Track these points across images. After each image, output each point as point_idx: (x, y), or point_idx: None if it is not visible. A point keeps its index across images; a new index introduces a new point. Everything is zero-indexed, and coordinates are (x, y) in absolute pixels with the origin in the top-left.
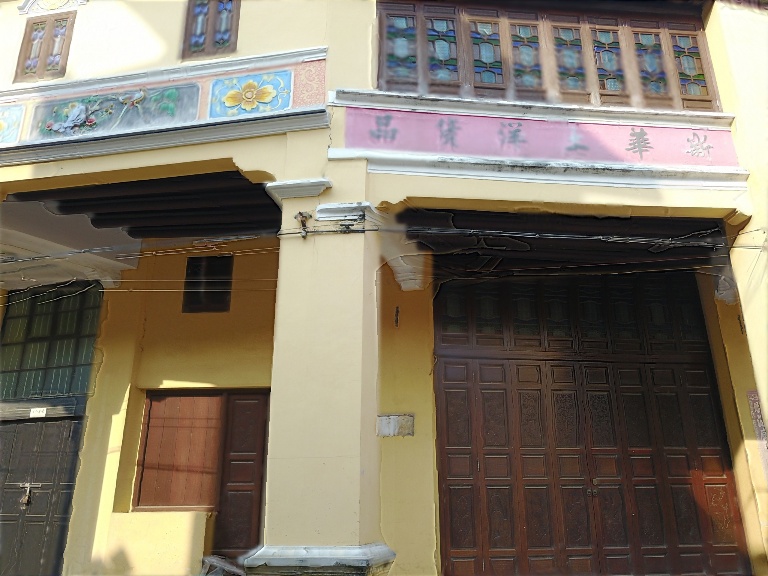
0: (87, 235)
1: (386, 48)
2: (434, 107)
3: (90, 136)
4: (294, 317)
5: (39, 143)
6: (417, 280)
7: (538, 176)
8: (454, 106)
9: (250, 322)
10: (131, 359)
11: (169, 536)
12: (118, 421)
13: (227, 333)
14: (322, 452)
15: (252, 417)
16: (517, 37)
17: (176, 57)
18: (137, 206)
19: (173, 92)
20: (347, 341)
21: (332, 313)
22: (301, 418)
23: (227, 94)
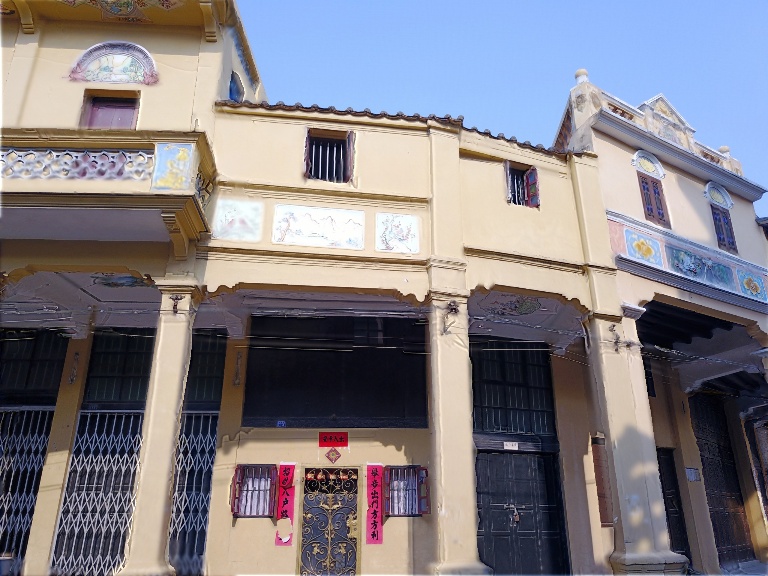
0: None
1: None
2: None
3: (715, 286)
4: None
5: (693, 280)
6: (698, 388)
7: None
8: None
9: None
10: None
11: None
12: (589, 460)
13: None
14: None
15: None
16: None
17: (716, 244)
18: None
19: (723, 268)
20: None
21: None
22: None
23: (744, 280)
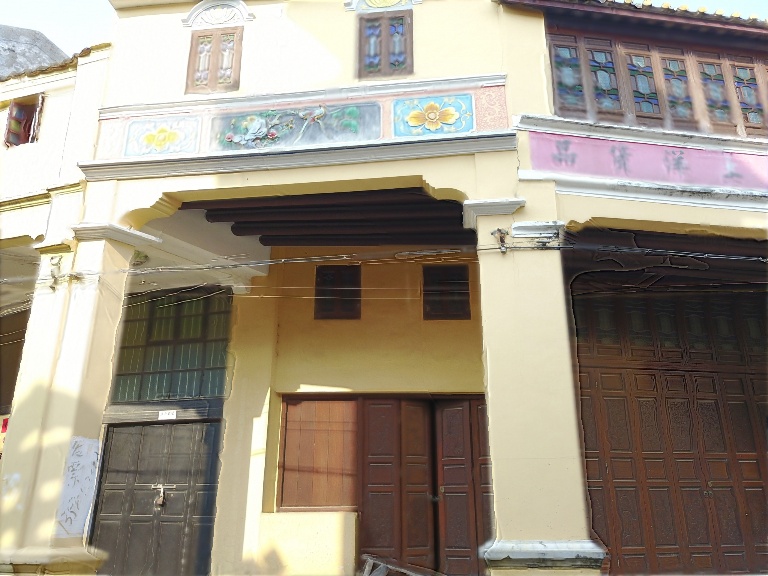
0: (229, 242)
1: (555, 76)
2: (606, 134)
3: (281, 150)
4: (503, 327)
5: (228, 154)
6: None
7: (703, 201)
8: (624, 133)
9: (382, 329)
10: (269, 363)
11: (320, 535)
12: (260, 424)
13: (360, 340)
14: (546, 453)
15: (387, 421)
16: (668, 71)
17: (353, 76)
18: (288, 216)
19: (354, 110)
20: (556, 350)
21: (539, 324)
22: (522, 422)
23: (410, 114)
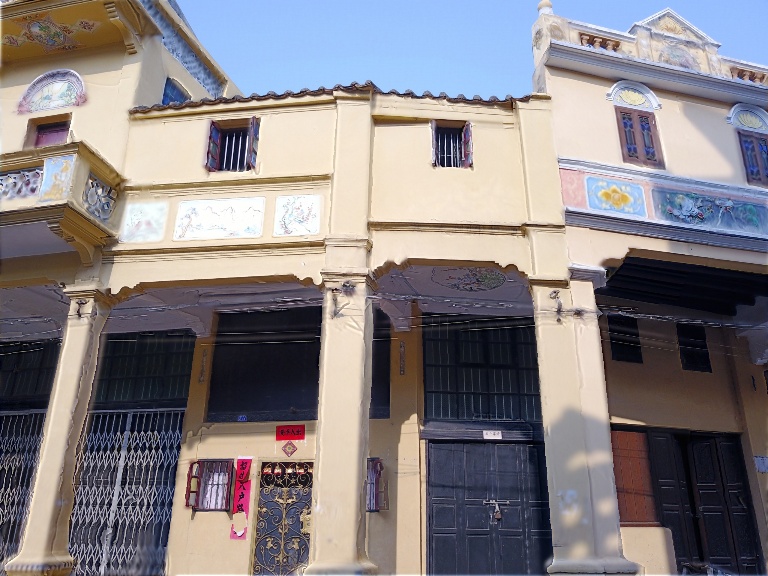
0: None
1: None
2: None
3: (726, 232)
4: None
5: (688, 227)
6: None
7: None
8: None
9: (658, 374)
10: None
11: (651, 547)
12: None
13: (645, 381)
14: None
15: None
16: None
17: (744, 179)
18: (641, 274)
19: (752, 208)
20: None
21: None
22: None
23: None
